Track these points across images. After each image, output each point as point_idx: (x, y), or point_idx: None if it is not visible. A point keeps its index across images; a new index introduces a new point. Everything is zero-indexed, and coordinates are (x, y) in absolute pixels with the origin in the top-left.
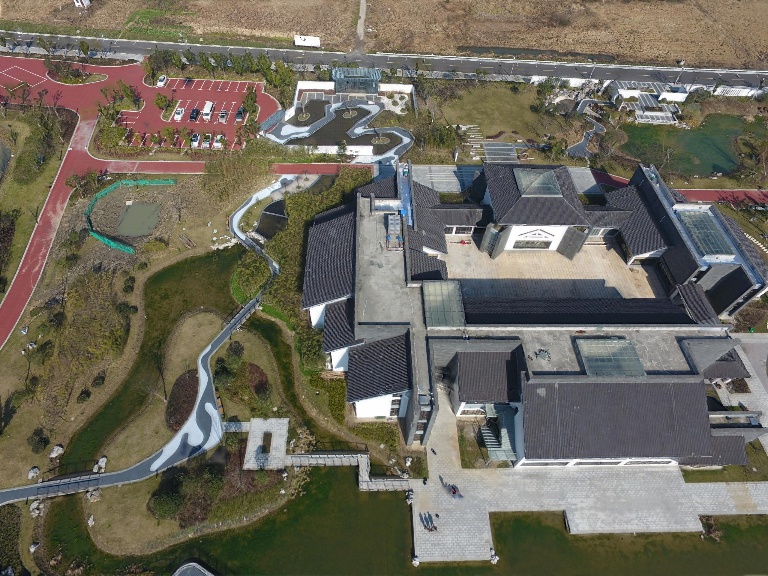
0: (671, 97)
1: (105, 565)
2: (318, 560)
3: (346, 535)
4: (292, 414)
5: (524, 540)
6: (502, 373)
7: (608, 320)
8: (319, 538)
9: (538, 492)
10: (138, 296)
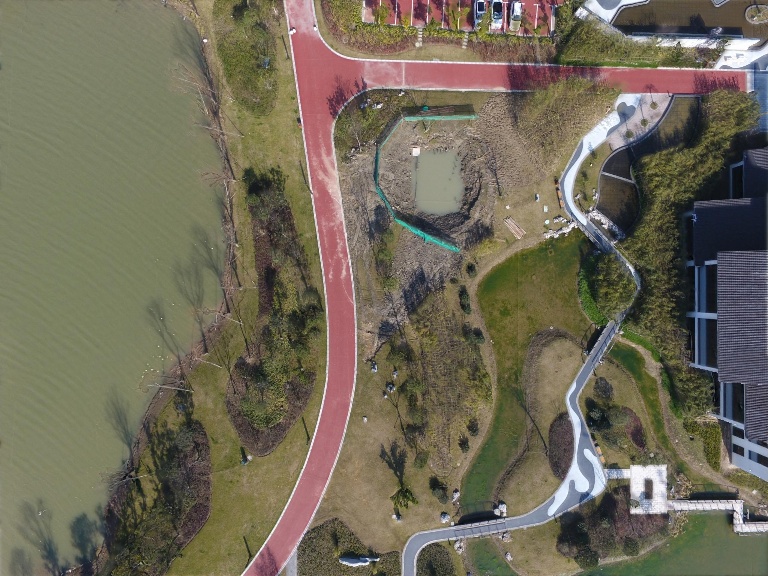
0: None
1: None
2: None
3: (719, 563)
4: (667, 459)
5: None
6: None
7: None
8: (697, 566)
9: None
10: (476, 313)
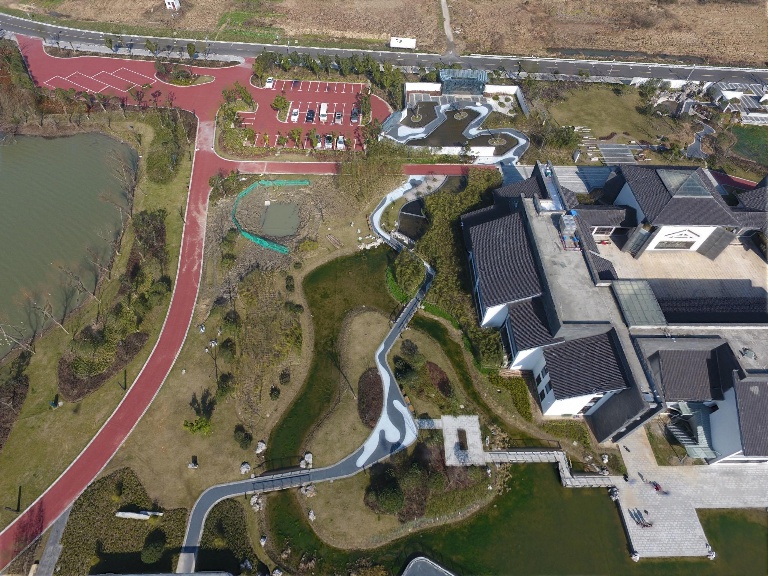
0: None
1: (334, 559)
2: (538, 555)
3: (559, 530)
4: (479, 411)
5: (734, 536)
6: (704, 371)
7: None
8: (534, 533)
9: (738, 489)
10: (300, 295)
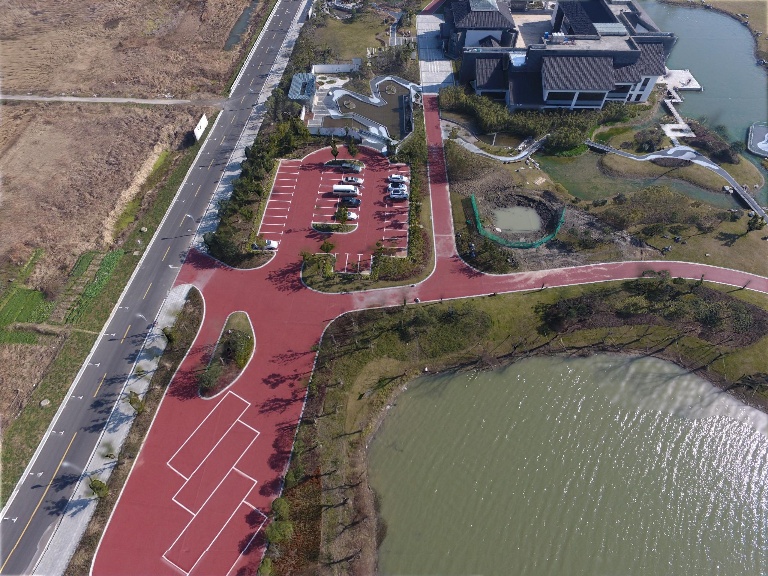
0: None
1: None
2: (718, 116)
3: None
4: None
5: (673, 65)
6: None
7: None
8: (709, 116)
9: None
10: None
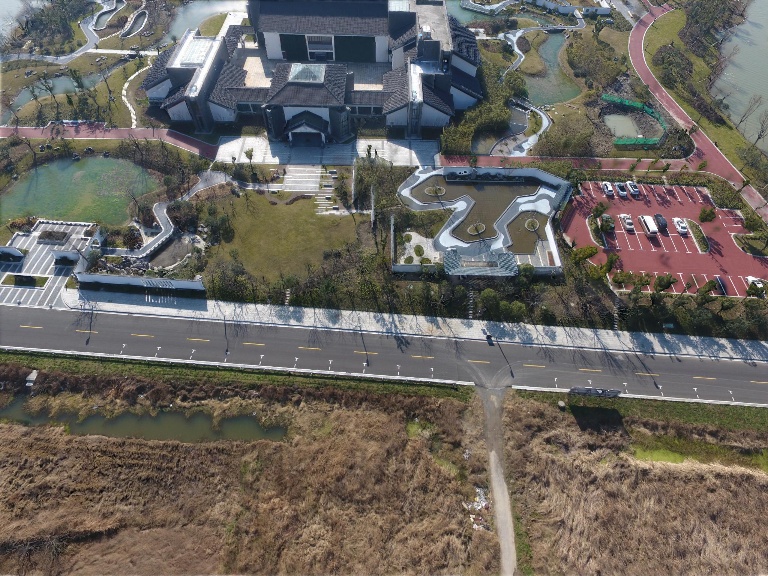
0: (4, 251)
1: None
2: None
3: None
4: None
5: None
6: None
7: (308, 9)
8: None
9: None
10: (580, 83)
